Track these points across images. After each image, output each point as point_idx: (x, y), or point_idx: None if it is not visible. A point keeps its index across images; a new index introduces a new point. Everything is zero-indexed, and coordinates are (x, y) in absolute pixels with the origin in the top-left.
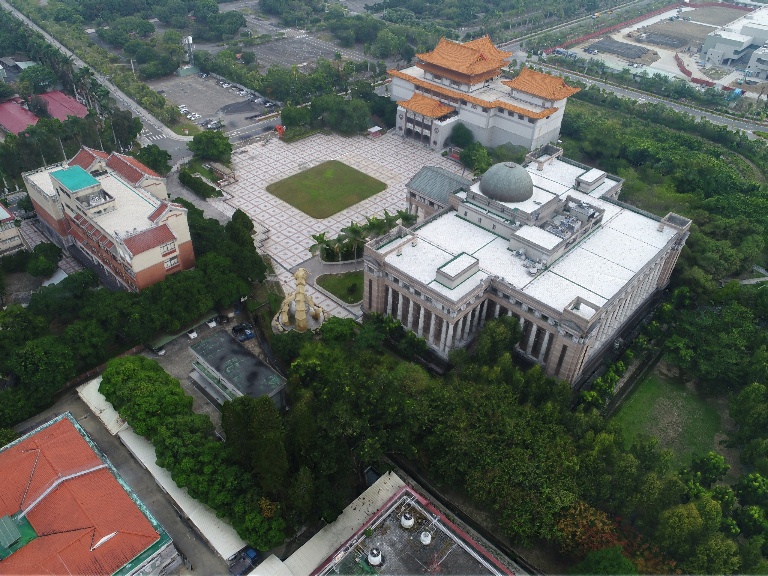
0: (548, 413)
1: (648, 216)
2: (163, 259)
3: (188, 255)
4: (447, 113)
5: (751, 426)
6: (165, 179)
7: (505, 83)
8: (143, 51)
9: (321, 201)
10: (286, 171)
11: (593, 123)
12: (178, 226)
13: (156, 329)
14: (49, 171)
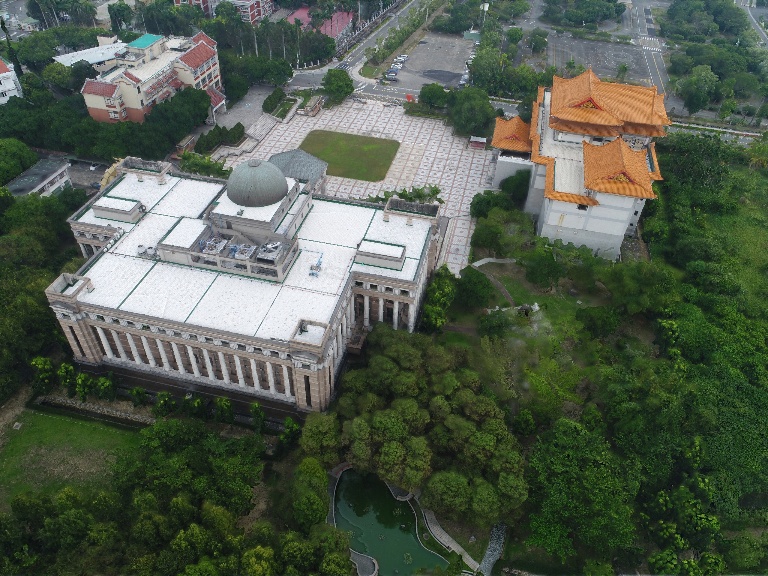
0: None
1: None
2: (107, 108)
3: (139, 120)
4: (517, 150)
5: None
6: (192, 69)
7: (585, 145)
8: (457, 7)
9: None
10: (352, 129)
11: (718, 274)
12: (129, 93)
13: (62, 144)
14: None
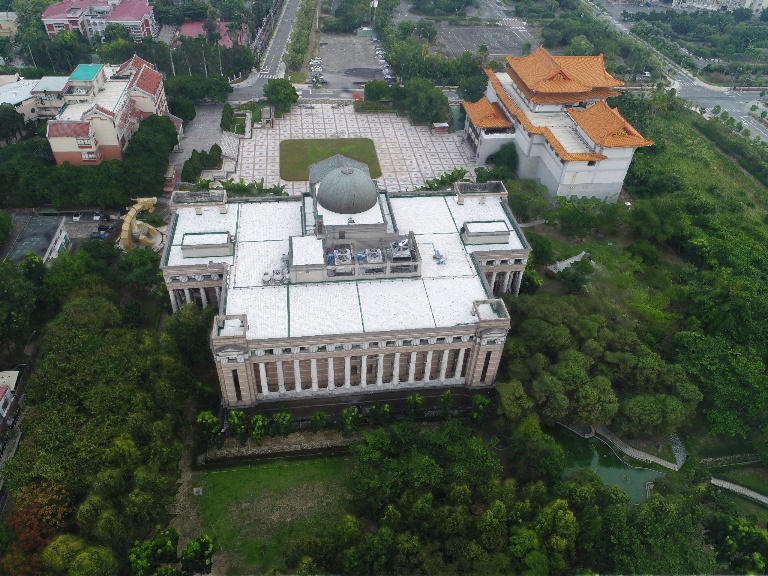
0: (135, 402)
1: (488, 294)
2: (80, 150)
3: (116, 158)
4: (499, 127)
5: (296, 552)
6: (153, 95)
7: (570, 111)
8: (341, 7)
9: (306, 167)
10: (318, 134)
11: (695, 198)
12: (104, 129)
13: (37, 198)
14: (111, 68)
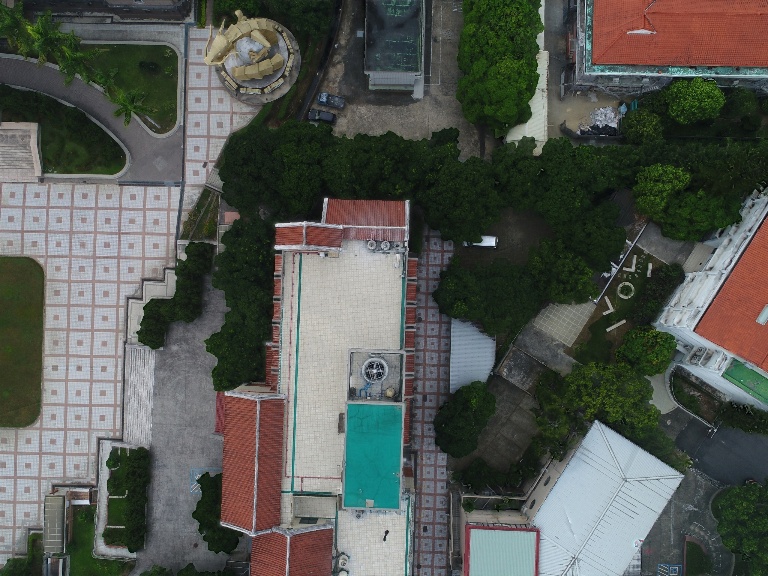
0: None
1: None
2: None
3: None
4: None
5: None
6: (226, 393)
7: None
8: None
9: None
10: None
11: None
12: None
13: None
14: None
